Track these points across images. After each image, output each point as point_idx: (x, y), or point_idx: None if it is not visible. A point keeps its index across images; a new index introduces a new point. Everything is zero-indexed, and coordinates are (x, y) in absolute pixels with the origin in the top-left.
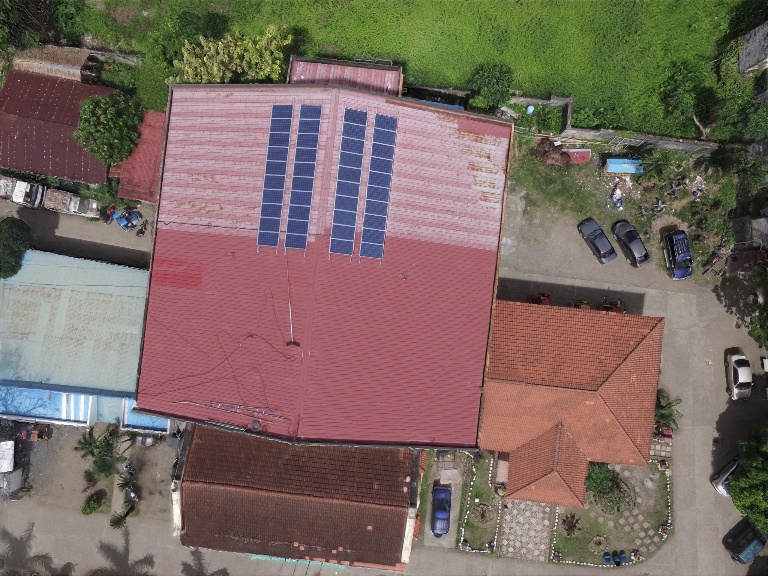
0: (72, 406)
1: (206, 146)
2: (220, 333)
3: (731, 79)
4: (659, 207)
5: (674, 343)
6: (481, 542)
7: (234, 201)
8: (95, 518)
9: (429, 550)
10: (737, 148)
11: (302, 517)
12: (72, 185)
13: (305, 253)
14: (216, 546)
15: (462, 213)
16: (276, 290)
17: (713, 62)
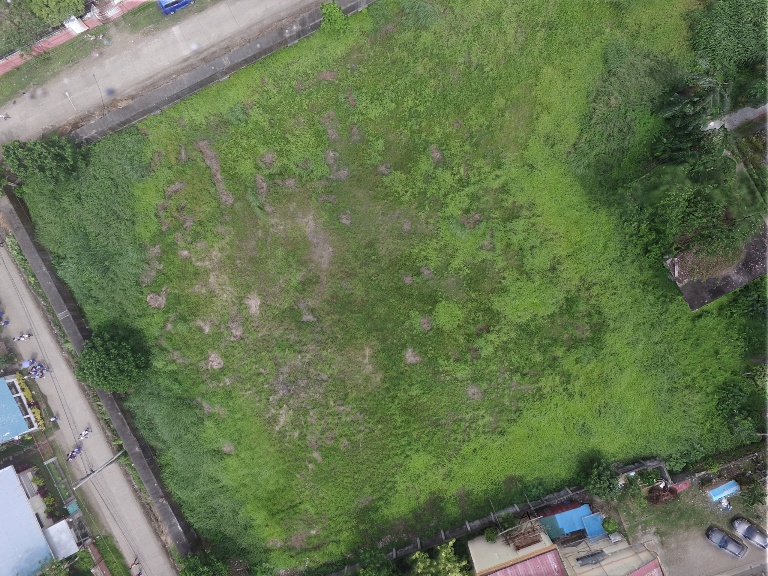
0: None
1: None
2: None
3: None
4: None
5: None
6: None
7: None
8: None
9: None
10: None
11: None
12: None
13: None
14: None
15: None
16: None
17: (746, 374)
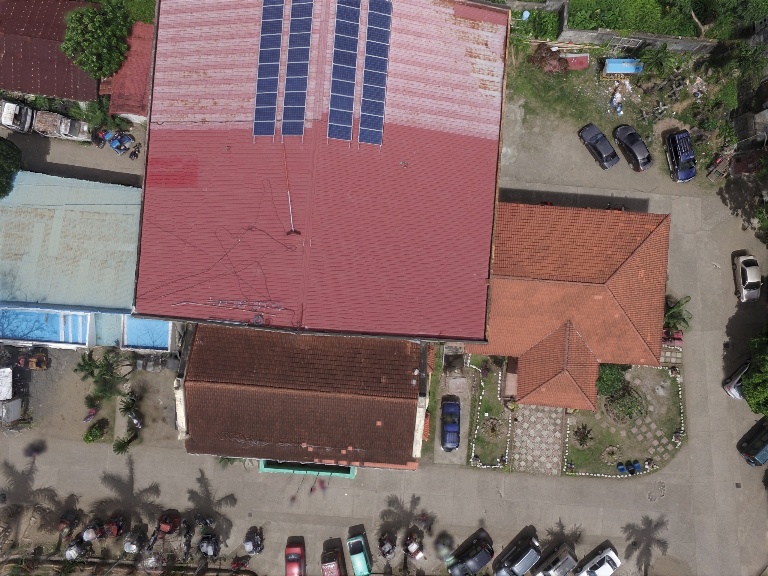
0: (70, 328)
1: (197, 41)
2: (218, 230)
3: None
4: (660, 109)
5: (680, 248)
6: (492, 457)
7: (228, 94)
8: (98, 448)
9: (440, 468)
10: (737, 43)
11: (309, 415)
12: (62, 106)
13: (302, 139)
14: (222, 451)
15: (461, 101)
16: (274, 180)
17: None
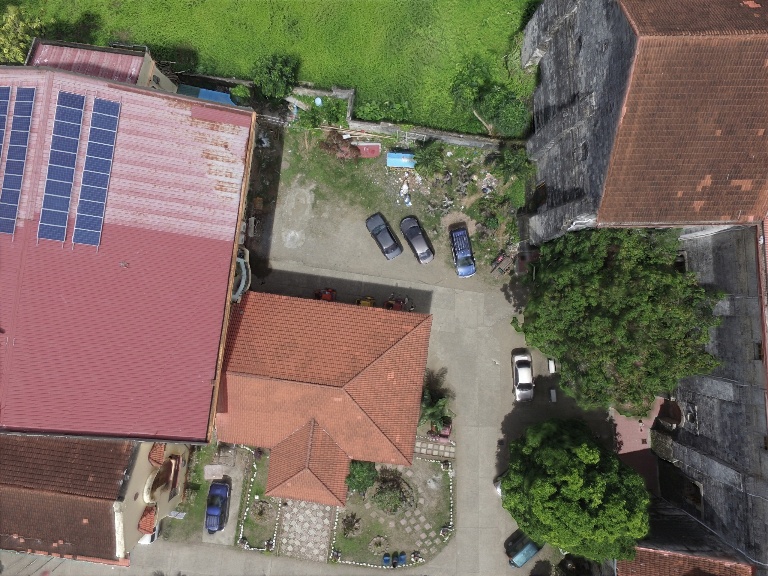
0: None
1: None
2: None
3: (516, 75)
4: (446, 203)
5: (461, 342)
6: (260, 540)
7: None
8: None
9: (208, 547)
10: (518, 145)
11: (16, 508)
12: None
13: (13, 238)
14: None
15: (194, 202)
16: None
17: (503, 58)
